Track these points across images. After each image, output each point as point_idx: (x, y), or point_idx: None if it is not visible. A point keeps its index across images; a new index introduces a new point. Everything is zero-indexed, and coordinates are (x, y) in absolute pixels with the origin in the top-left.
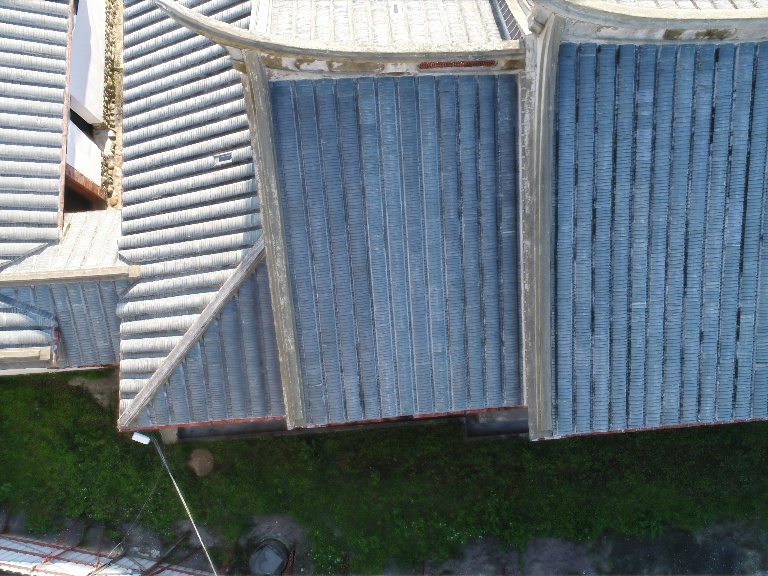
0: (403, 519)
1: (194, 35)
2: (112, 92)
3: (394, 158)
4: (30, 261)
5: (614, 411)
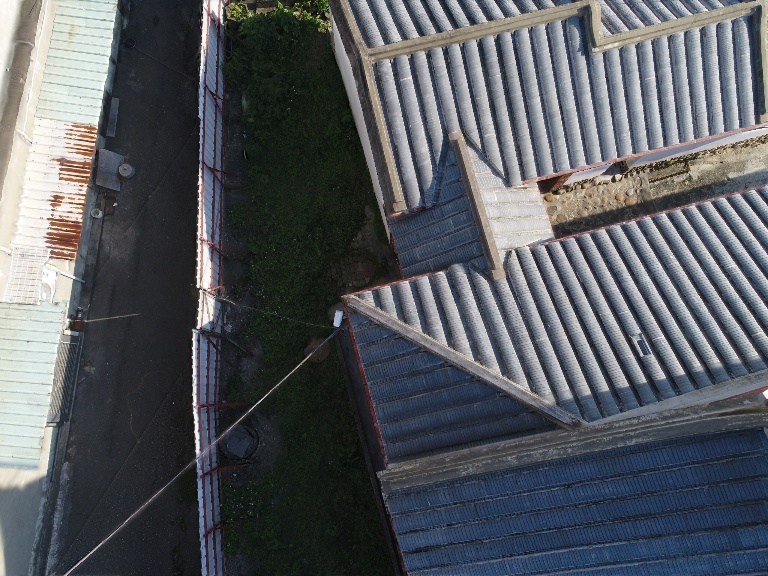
0: (299, 570)
1: (767, 275)
2: (662, 166)
3: (706, 570)
4: (485, 169)
5: None
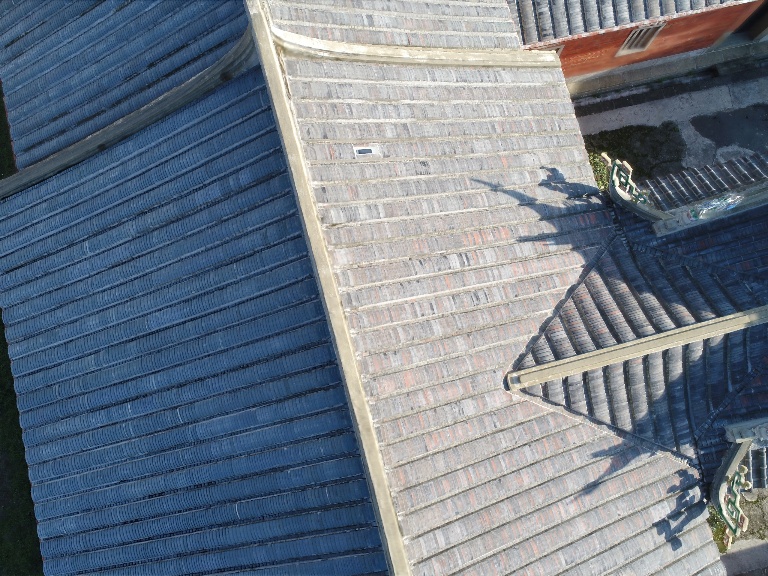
0: None
1: None
2: None
3: None
4: None
5: (6, 258)
